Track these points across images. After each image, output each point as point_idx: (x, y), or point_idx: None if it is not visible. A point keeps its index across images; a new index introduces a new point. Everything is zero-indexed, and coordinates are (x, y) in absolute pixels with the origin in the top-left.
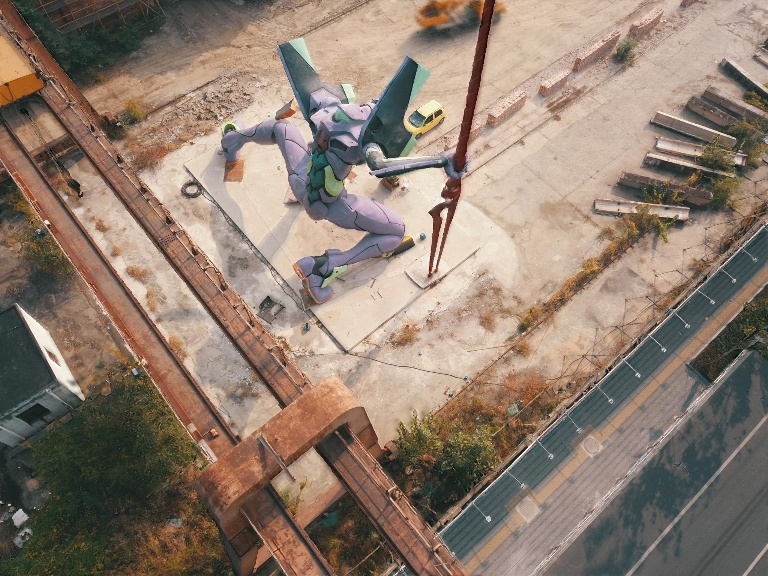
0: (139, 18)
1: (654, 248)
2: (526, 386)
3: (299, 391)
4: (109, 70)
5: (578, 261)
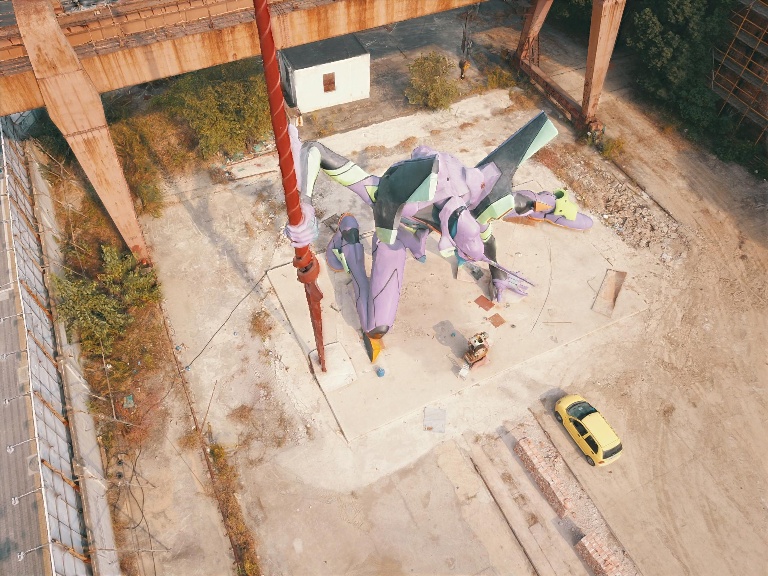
0: None
1: None
2: None
3: (95, 51)
4: (682, 138)
5: None
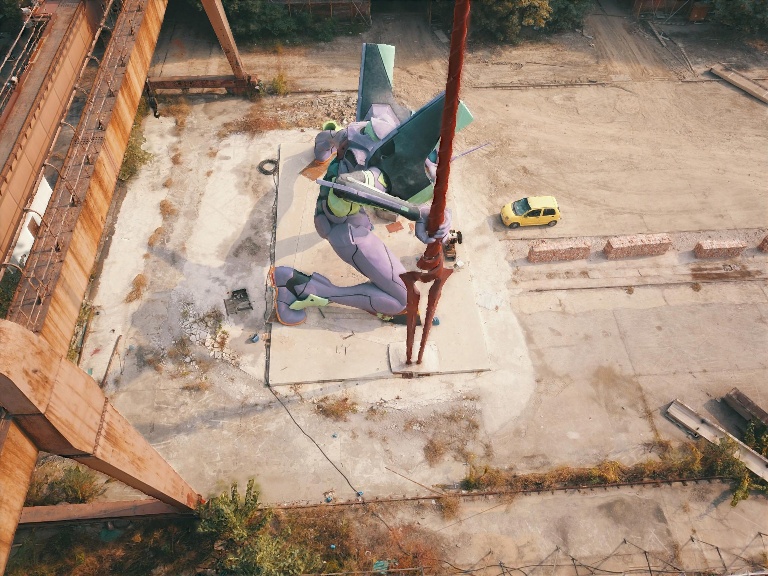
0: (349, 19)
1: (715, 504)
2: (416, 551)
3: None
4: (292, 47)
5: (597, 455)
